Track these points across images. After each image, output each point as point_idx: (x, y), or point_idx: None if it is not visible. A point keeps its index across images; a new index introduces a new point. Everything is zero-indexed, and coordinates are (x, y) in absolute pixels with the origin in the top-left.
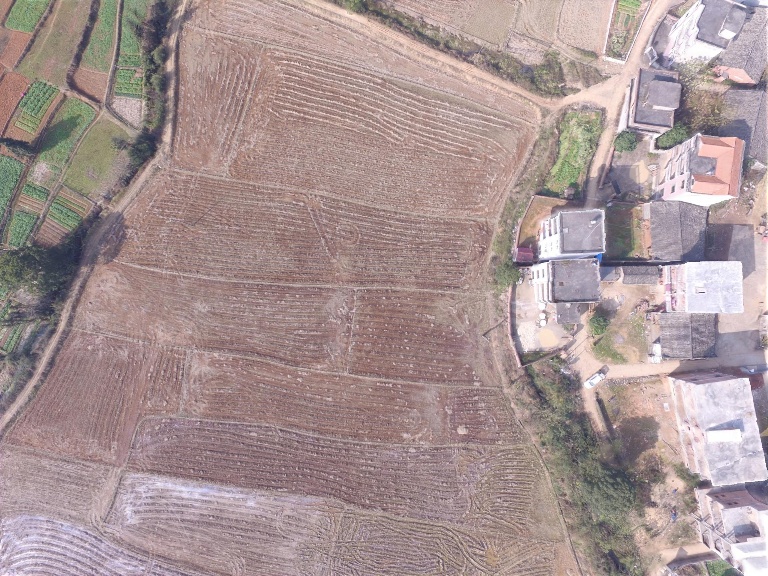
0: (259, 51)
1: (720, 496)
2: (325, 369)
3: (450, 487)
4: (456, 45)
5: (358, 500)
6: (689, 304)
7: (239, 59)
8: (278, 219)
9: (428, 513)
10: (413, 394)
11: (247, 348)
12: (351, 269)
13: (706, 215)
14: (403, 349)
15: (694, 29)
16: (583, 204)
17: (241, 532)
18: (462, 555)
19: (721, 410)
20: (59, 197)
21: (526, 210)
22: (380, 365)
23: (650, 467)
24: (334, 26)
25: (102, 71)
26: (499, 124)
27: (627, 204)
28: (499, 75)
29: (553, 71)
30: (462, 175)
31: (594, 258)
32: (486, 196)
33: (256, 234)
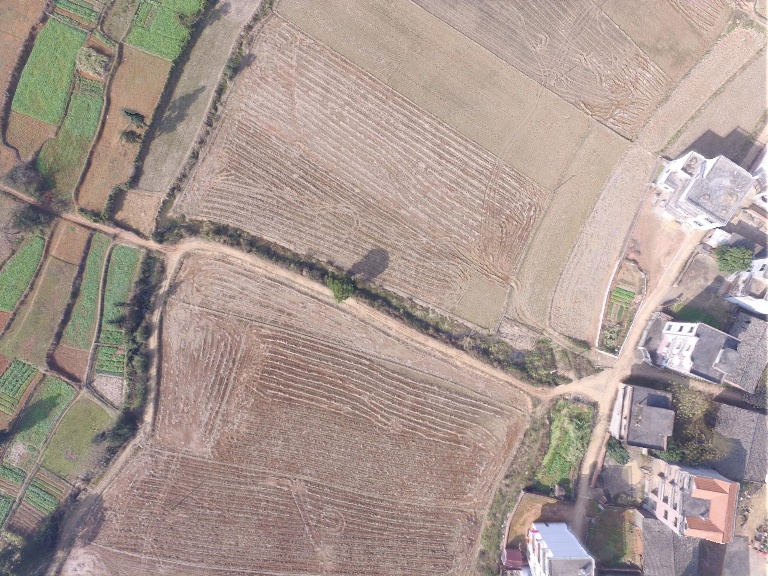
0: (244, 328)
1: None
2: None
3: None
4: (446, 327)
5: None
6: None
7: (224, 336)
8: (261, 504)
9: None
10: None
11: None
12: (335, 558)
13: None
14: None
15: (688, 359)
16: (574, 503)
17: None
18: None
19: None
20: (36, 479)
21: (516, 506)
22: None
23: None
24: (321, 304)
25: (83, 348)
26: (489, 411)
27: (619, 507)
28: (489, 362)
29: (544, 357)
30: (450, 463)
31: None
32: (475, 485)
33: (238, 519)
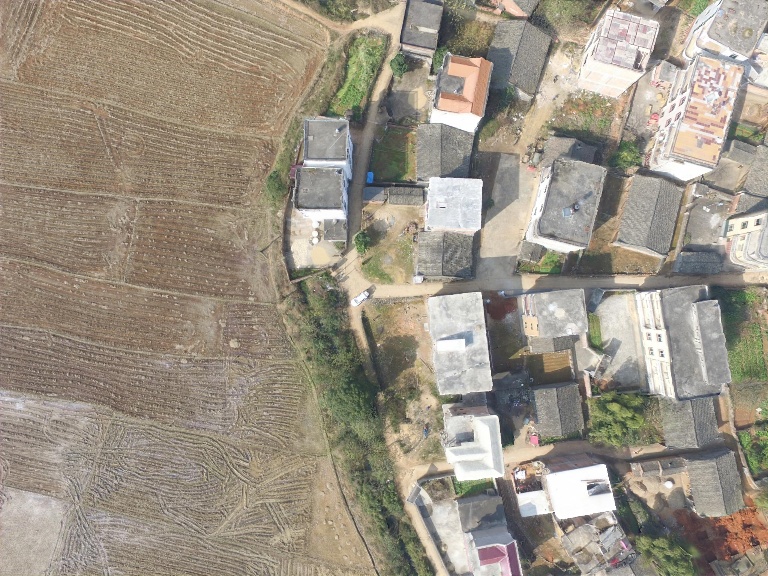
0: None
1: (458, 409)
2: (102, 277)
3: (218, 399)
4: None
5: (127, 408)
6: (429, 218)
7: None
8: (64, 126)
9: (195, 423)
10: (188, 306)
11: (25, 252)
12: (134, 179)
13: (473, 141)
14: (181, 261)
15: None
16: (363, 127)
17: (8, 435)
18: (226, 466)
19: (453, 322)
20: None
21: None
22: (157, 276)
23: (409, 385)
24: None
25: None
26: (290, 45)
27: (403, 128)
28: None
29: None
30: (250, 93)
31: (339, 167)
32: (273, 115)
33: (41, 139)
